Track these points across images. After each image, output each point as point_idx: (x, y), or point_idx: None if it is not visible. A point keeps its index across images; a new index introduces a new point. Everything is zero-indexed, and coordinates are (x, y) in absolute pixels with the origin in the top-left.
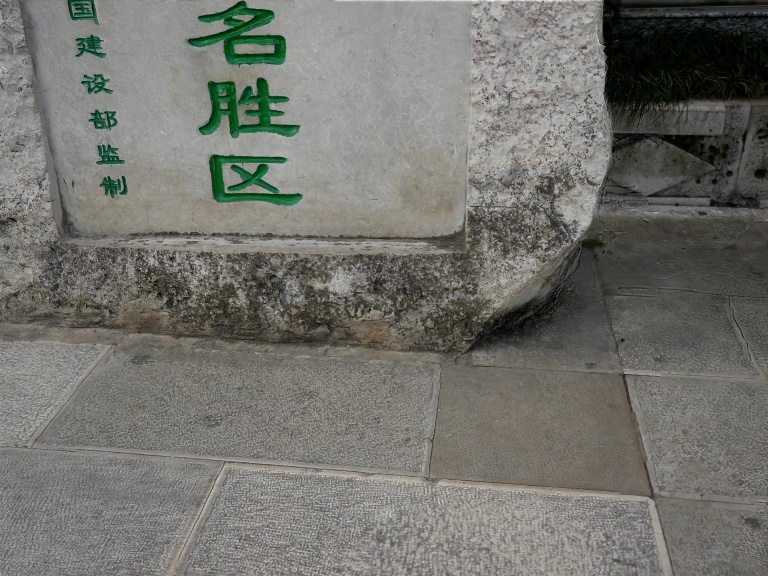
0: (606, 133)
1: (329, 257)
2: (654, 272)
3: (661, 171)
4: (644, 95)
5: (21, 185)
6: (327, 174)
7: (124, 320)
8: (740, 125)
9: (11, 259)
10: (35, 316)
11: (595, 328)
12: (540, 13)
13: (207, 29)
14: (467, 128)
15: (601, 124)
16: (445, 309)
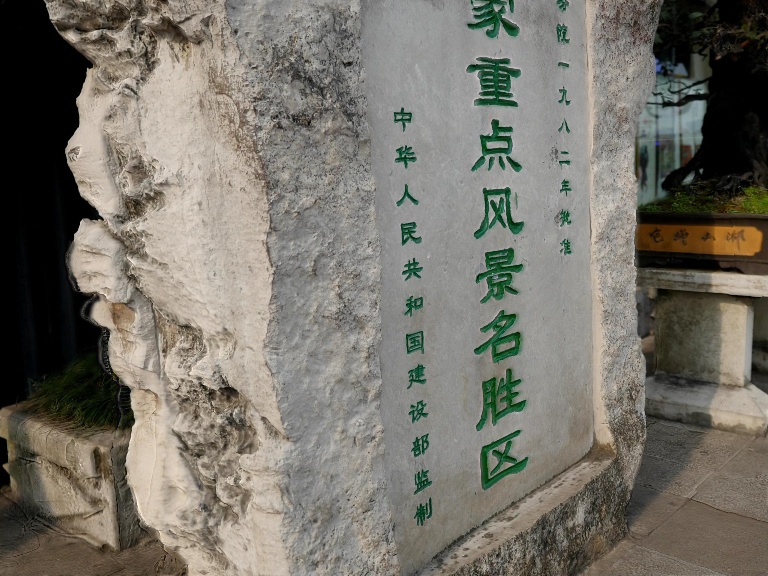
0: None
1: (575, 496)
2: None
3: None
4: None
5: (368, 550)
6: (539, 433)
7: None
8: None
9: None
10: None
11: None
12: (619, 288)
13: (484, 338)
14: (592, 371)
15: None
16: (617, 504)
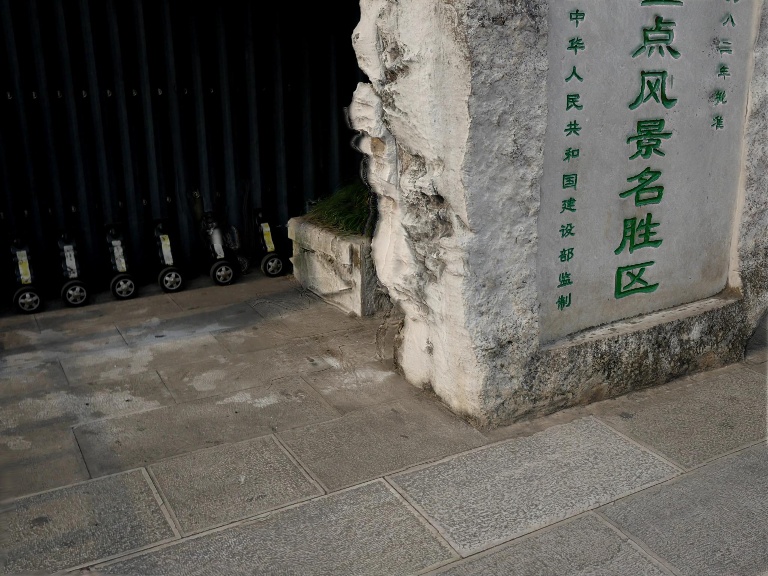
0: None
1: (693, 317)
2: None
3: None
4: None
5: (518, 313)
6: (672, 267)
7: (581, 397)
8: None
9: (505, 374)
10: (519, 415)
11: (762, 332)
12: None
13: (630, 186)
14: (733, 227)
15: None
16: (736, 335)
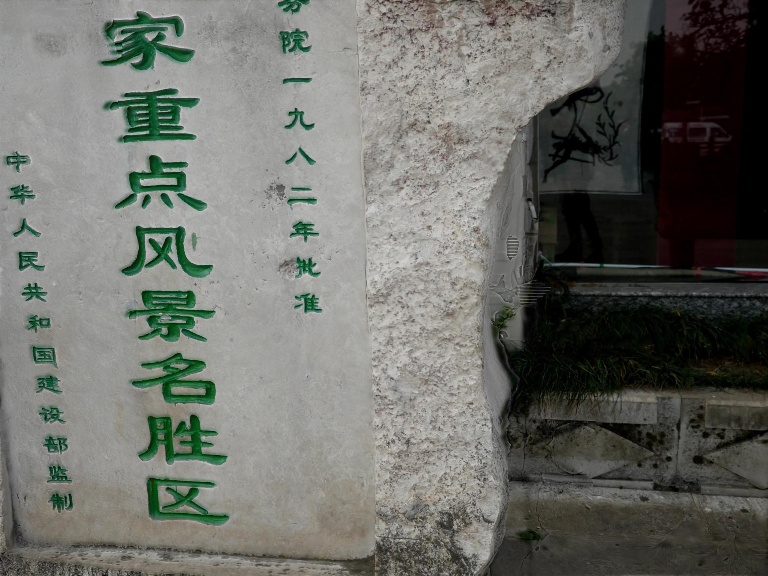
0: (497, 475)
1: None
2: (583, 575)
3: (602, 455)
4: (580, 385)
5: None
6: (251, 499)
7: None
8: (673, 414)
9: None
10: None
11: None
12: (430, 374)
13: (149, 374)
14: (374, 465)
15: (492, 467)
16: None
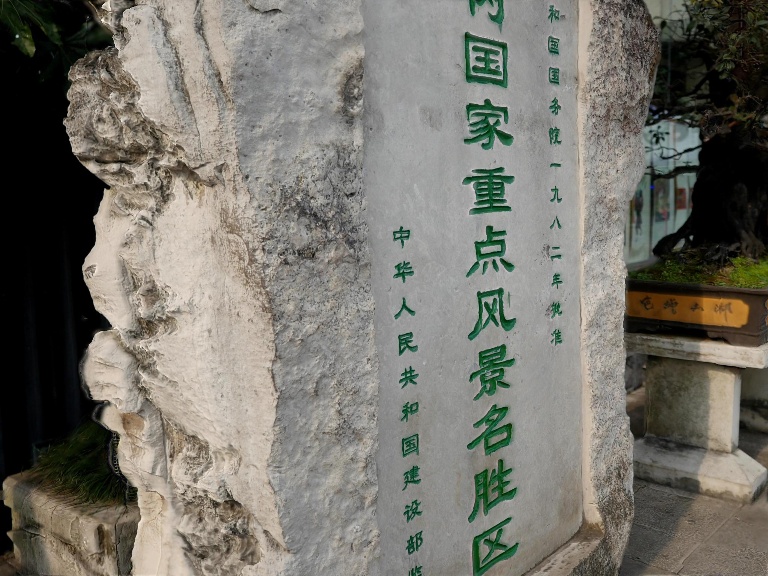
0: None
1: None
2: None
3: None
4: None
5: None
6: (529, 518)
7: None
8: None
9: None
10: None
11: None
12: None
13: (477, 433)
14: (582, 452)
15: None
16: None
